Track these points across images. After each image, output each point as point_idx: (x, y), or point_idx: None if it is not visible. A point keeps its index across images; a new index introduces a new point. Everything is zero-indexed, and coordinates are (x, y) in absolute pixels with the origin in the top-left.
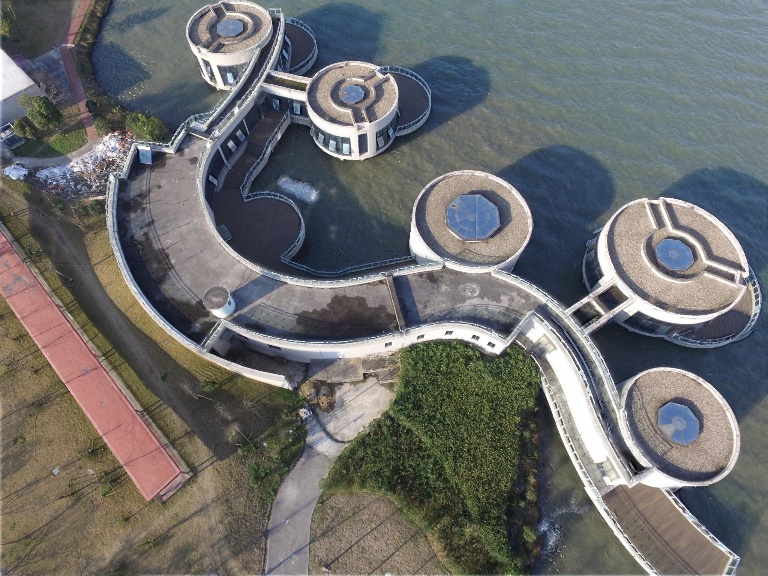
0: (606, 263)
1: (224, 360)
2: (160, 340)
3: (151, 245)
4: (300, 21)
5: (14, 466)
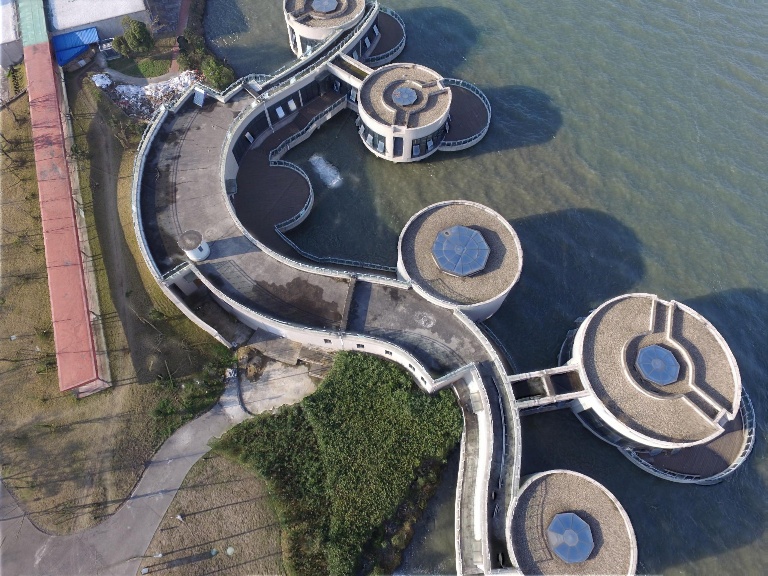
0: (577, 345)
1: (175, 297)
2: (139, 261)
3: (168, 176)
4: (398, 15)
5: None
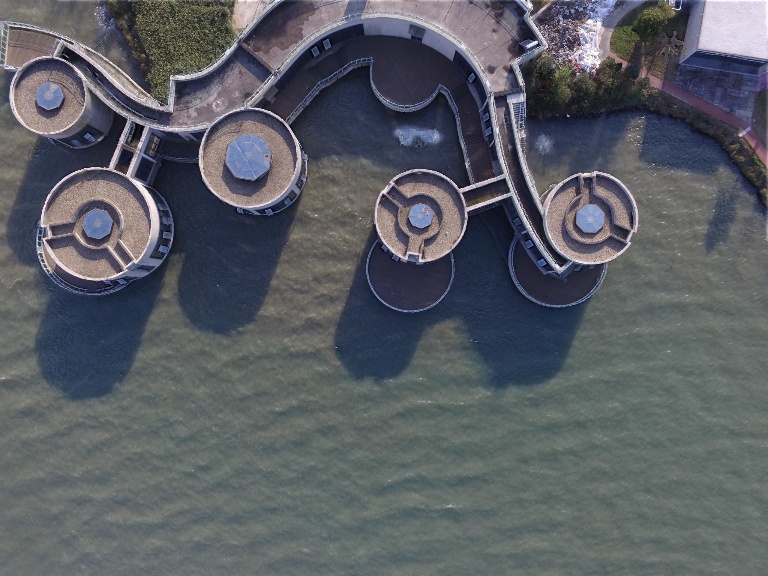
0: (140, 186)
1: None
2: None
3: None
4: None
5: None
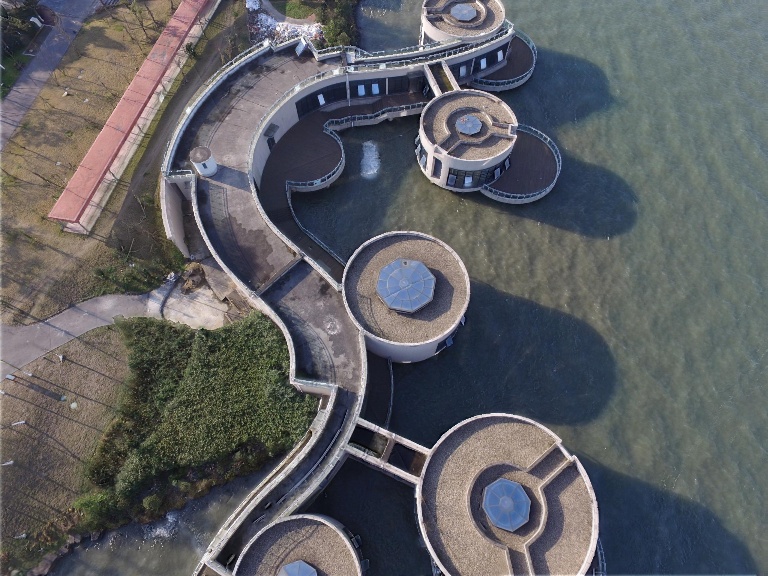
0: None
1: (164, 193)
2: None
3: (232, 99)
4: (536, 51)
5: (53, 142)
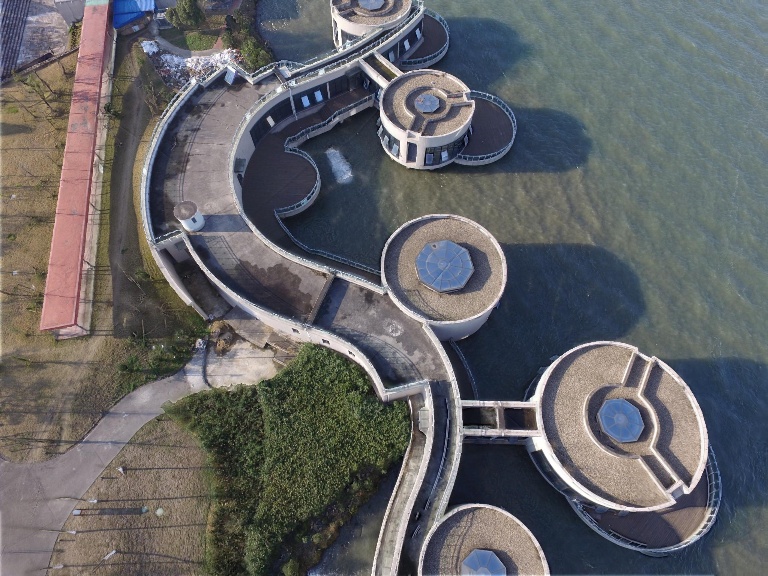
0: (541, 383)
1: (161, 262)
2: (141, 222)
3: (184, 146)
4: (446, 22)
5: None
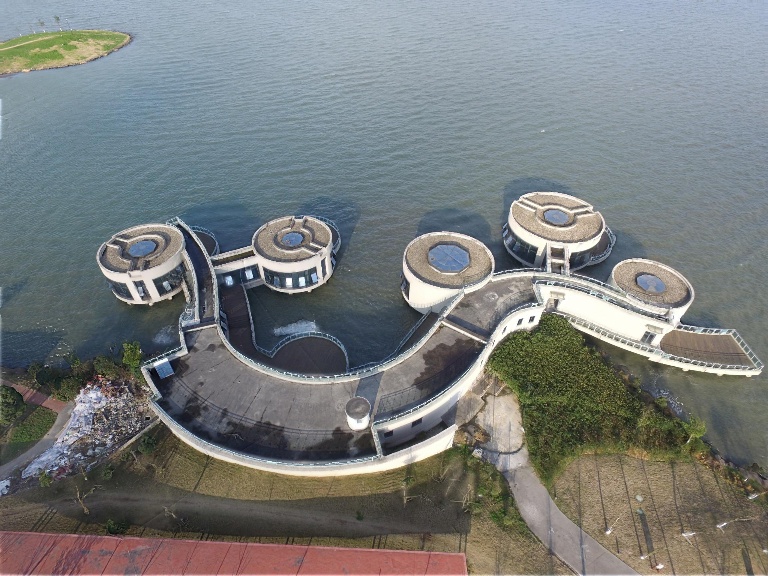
0: (535, 239)
1: (404, 450)
2: (326, 492)
3: (244, 427)
4: None
5: None
